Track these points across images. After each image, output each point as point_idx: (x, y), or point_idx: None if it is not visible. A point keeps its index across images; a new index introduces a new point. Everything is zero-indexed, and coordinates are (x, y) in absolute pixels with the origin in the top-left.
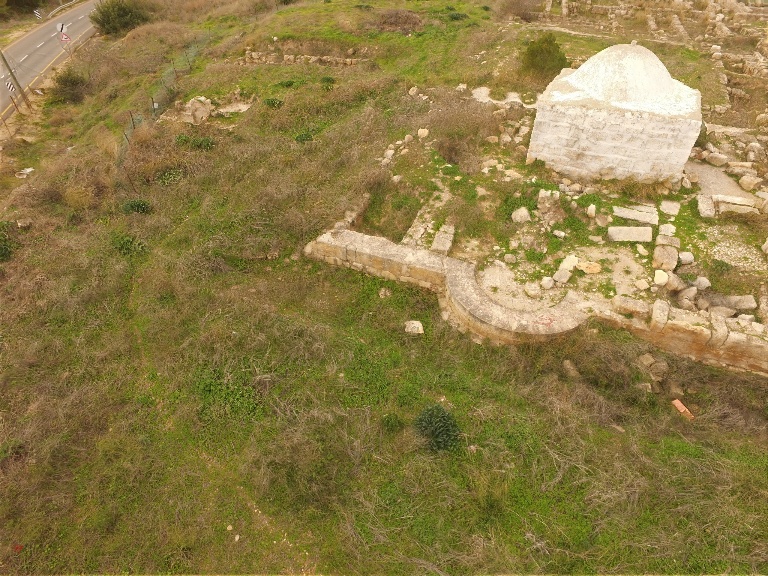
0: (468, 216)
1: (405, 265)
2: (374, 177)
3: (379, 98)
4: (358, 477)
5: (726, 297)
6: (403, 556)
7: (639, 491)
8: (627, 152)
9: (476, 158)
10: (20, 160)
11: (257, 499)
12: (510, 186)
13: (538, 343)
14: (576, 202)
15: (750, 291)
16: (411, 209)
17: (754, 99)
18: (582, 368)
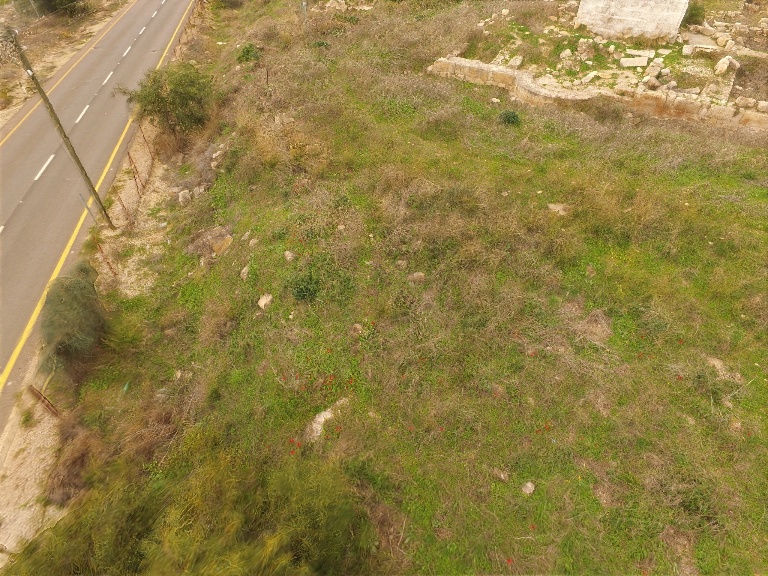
0: (532, 52)
1: (491, 72)
2: (473, 31)
3: (471, 0)
4: (468, 132)
5: (684, 89)
6: (491, 149)
7: (605, 132)
8: (641, 15)
9: (540, 28)
10: (211, 38)
11: (420, 136)
12: (561, 38)
13: (566, 104)
14: (603, 45)
15: (699, 87)
16: (495, 49)
17: (766, 13)
18: (589, 113)
